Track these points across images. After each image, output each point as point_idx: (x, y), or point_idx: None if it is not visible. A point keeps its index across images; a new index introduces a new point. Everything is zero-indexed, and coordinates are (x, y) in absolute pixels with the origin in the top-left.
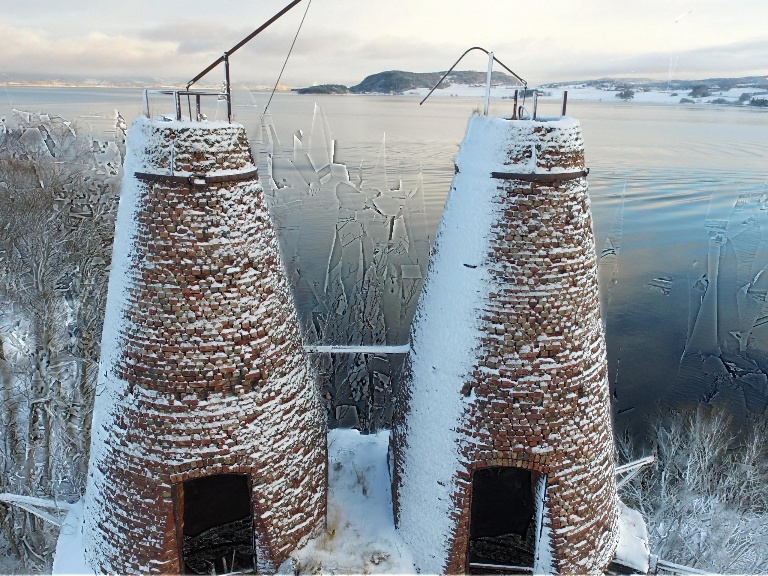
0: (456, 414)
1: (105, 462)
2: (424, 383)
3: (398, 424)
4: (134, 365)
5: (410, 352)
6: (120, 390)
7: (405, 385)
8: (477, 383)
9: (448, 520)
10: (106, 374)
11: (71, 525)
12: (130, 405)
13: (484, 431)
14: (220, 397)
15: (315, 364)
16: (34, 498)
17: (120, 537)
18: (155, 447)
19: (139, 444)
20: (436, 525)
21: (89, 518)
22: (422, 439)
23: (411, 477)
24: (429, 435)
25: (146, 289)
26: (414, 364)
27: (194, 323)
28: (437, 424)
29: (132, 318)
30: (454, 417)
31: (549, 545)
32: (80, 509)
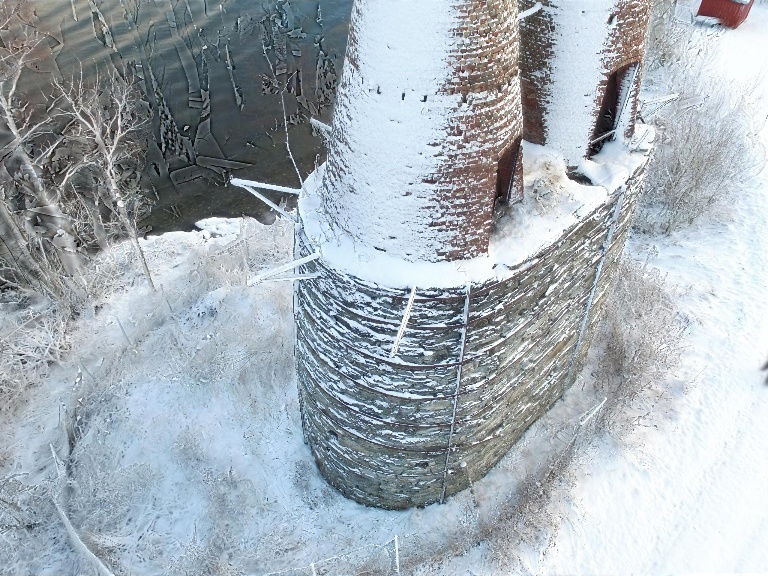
0: (603, 40)
1: (438, 172)
2: (573, 27)
3: (535, 71)
4: (469, 76)
5: (545, 9)
6: (453, 104)
7: (543, 37)
8: (620, 11)
9: (592, 118)
10: (425, 99)
11: (361, 255)
12: (466, 112)
13: (620, 45)
14: (514, 80)
15: (134, 114)
16: (281, 267)
17: (459, 220)
18: (488, 137)
19: (476, 141)
20: (583, 125)
21: (411, 228)
22: (571, 70)
23: (559, 103)
24: (579, 65)
25: (477, 1)
26: (557, 16)
27: (507, 21)
28: (586, 54)
29: (465, 33)
30: (601, 43)
31: (631, 109)
32: (336, 249)
